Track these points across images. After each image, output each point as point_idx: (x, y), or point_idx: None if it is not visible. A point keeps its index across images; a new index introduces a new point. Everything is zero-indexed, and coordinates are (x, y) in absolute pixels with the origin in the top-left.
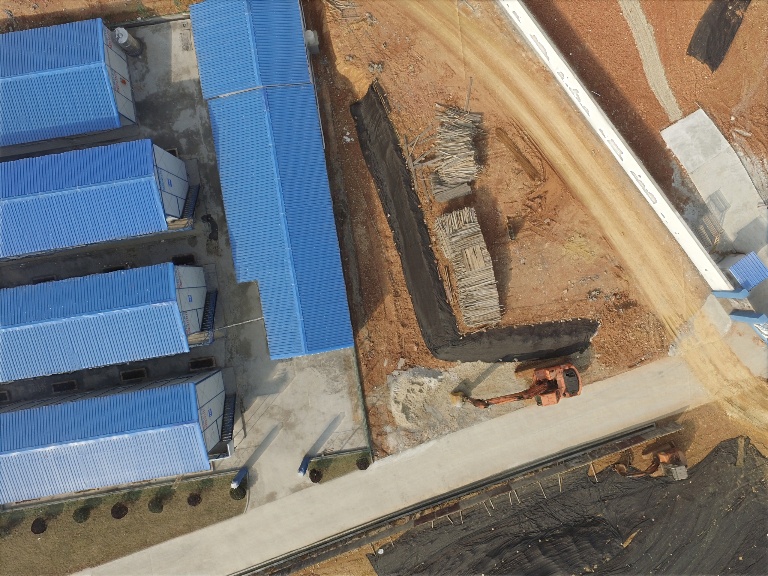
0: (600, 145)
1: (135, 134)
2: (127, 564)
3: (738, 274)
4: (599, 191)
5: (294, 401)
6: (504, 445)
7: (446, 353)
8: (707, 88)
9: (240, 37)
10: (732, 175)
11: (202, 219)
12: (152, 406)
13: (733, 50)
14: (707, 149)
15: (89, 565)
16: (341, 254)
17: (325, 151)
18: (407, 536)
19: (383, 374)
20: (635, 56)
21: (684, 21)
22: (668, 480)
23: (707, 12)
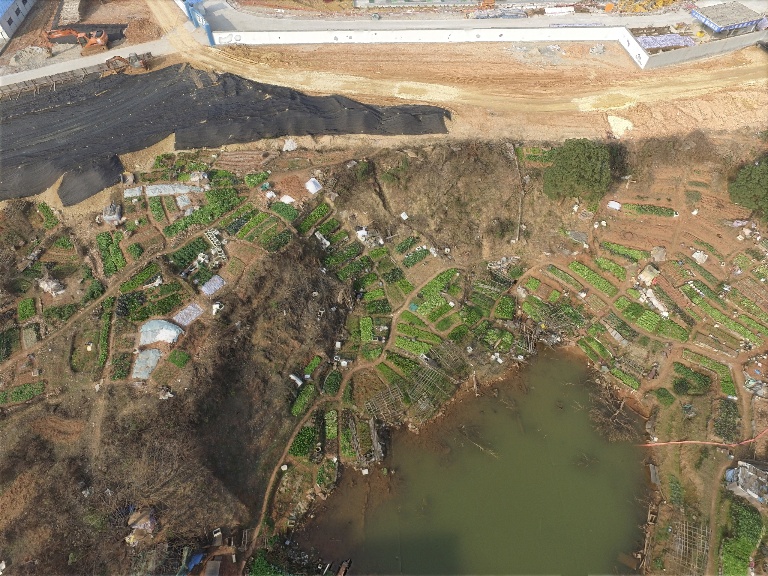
0: None
1: None
2: None
3: None
4: None
5: None
6: (61, 71)
7: None
8: None
9: None
10: None
11: None
12: None
13: None
14: None
15: None
16: (27, 17)
17: None
18: None
19: None
20: None
21: None
22: None
23: None
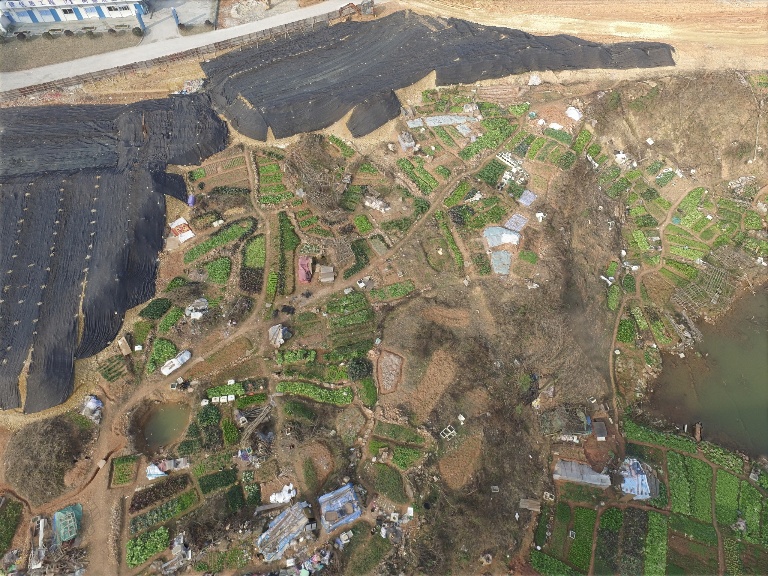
0: None
1: None
2: (57, 67)
3: None
4: None
5: (182, 10)
6: (286, 21)
7: None
8: None
9: None
10: None
11: None
12: None
13: None
14: None
15: (35, 67)
16: None
17: None
18: None
19: (230, 4)
20: None
21: None
22: None
23: None
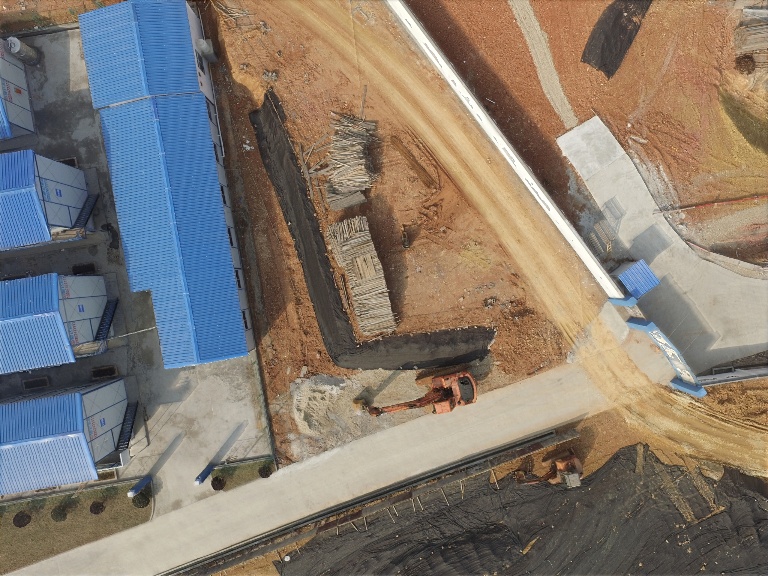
0: (495, 153)
1: (34, 143)
2: (35, 572)
3: (627, 282)
4: (495, 199)
5: (197, 409)
6: (407, 452)
7: (346, 361)
8: (603, 95)
9: (127, 47)
10: (627, 182)
11: (102, 228)
12: (38, 416)
13: (630, 57)
14: (602, 156)
15: None
16: (242, 262)
17: (225, 159)
18: (313, 543)
19: (286, 382)
20: (529, 63)
21: (578, 28)
22: None
23: (601, 19)
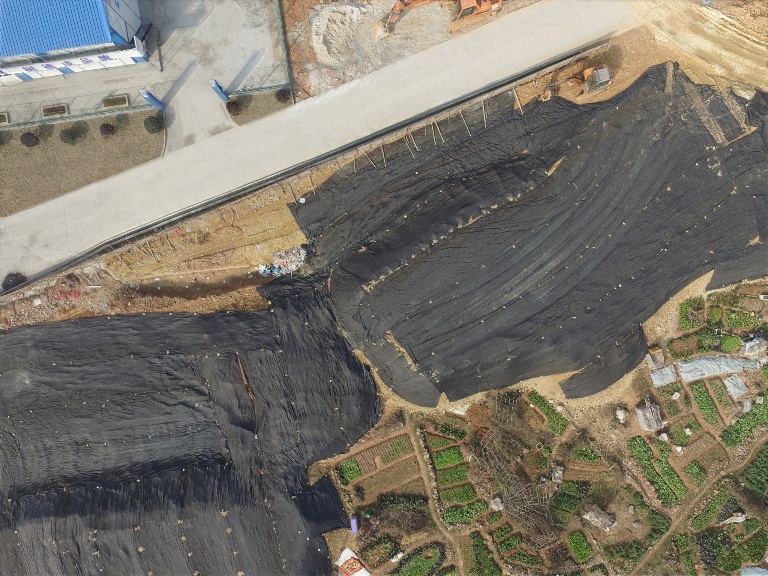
0: None
1: None
2: (41, 214)
3: None
4: None
5: (213, 35)
6: (428, 81)
7: None
8: None
9: None
10: None
11: None
12: None
13: None
14: None
15: (1, 214)
16: None
17: None
18: (329, 183)
19: (305, 8)
20: None
21: None
22: (594, 107)
23: None
